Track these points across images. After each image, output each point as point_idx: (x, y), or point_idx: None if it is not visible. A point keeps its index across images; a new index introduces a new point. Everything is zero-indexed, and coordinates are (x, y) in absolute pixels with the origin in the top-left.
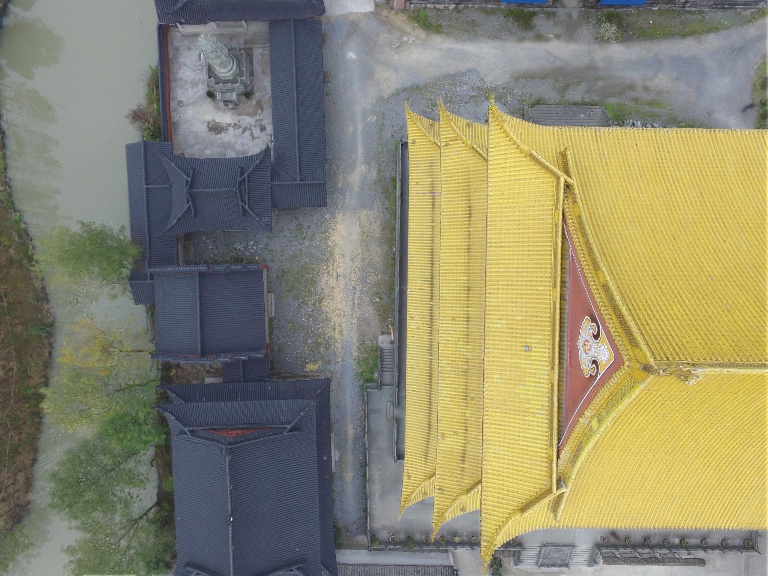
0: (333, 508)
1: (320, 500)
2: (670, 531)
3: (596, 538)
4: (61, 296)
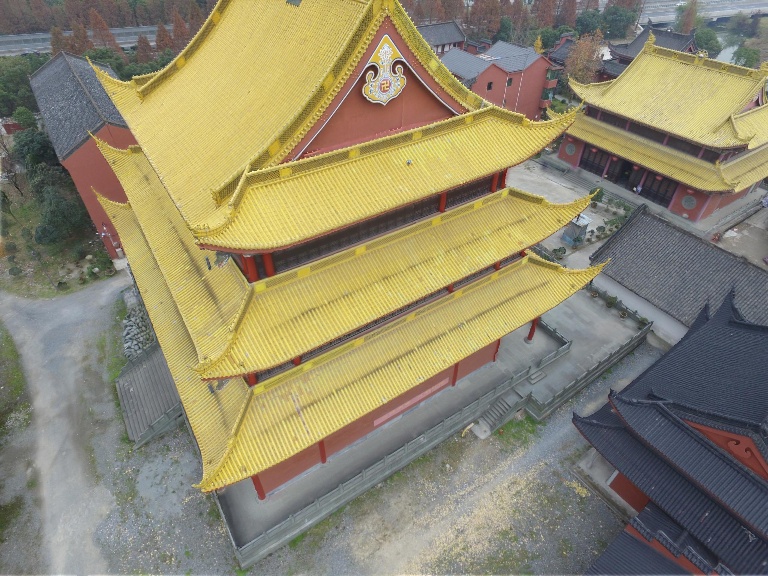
0: None
1: None
2: None
3: None
4: None
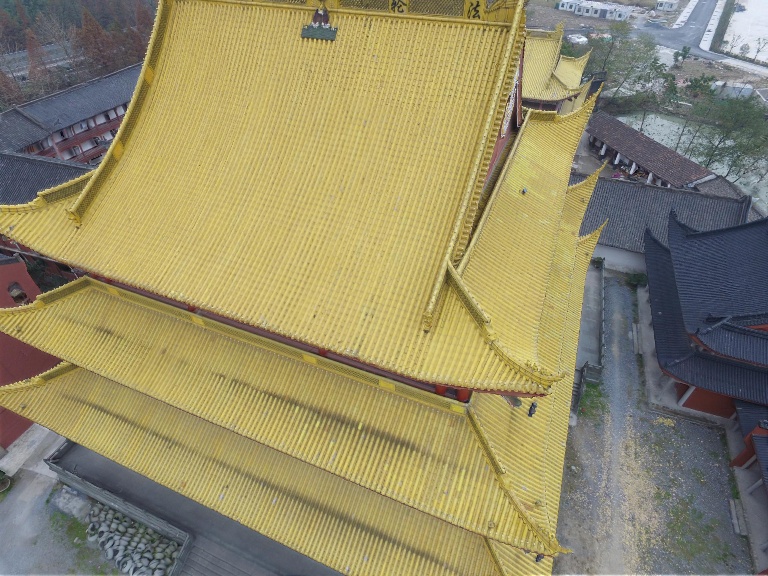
0: (634, 300)
1: (664, 285)
2: None
3: None
4: None
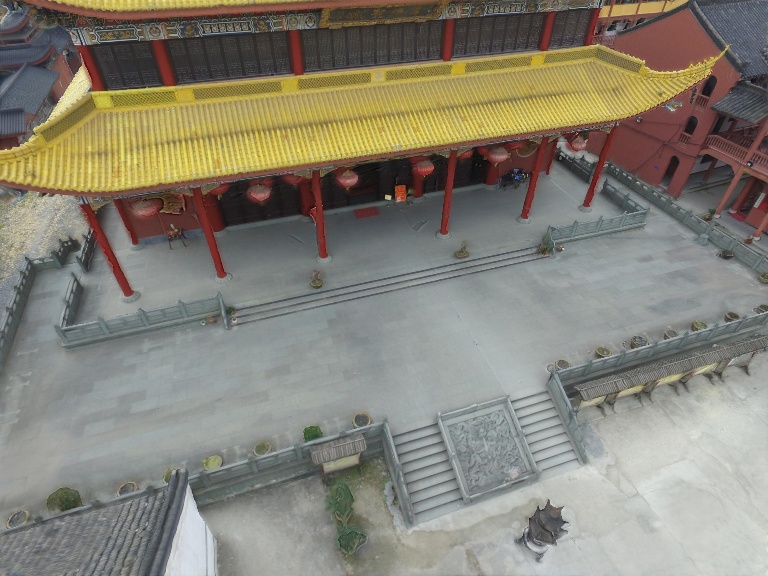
0: None
1: None
2: (661, 323)
3: (541, 372)
4: None
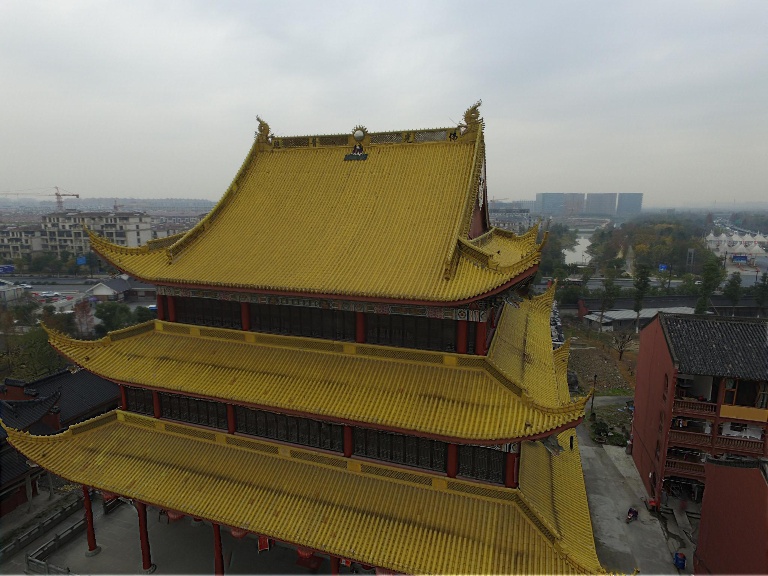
0: None
1: None
2: None
3: None
4: (1, 347)
